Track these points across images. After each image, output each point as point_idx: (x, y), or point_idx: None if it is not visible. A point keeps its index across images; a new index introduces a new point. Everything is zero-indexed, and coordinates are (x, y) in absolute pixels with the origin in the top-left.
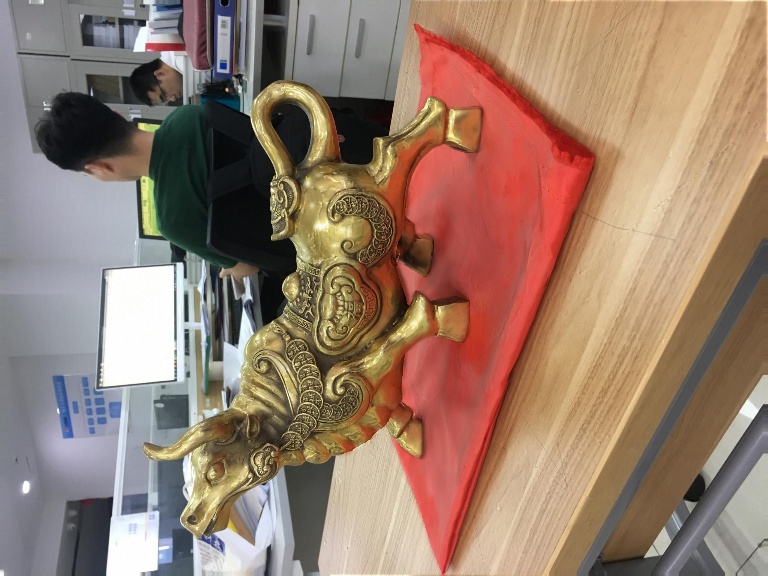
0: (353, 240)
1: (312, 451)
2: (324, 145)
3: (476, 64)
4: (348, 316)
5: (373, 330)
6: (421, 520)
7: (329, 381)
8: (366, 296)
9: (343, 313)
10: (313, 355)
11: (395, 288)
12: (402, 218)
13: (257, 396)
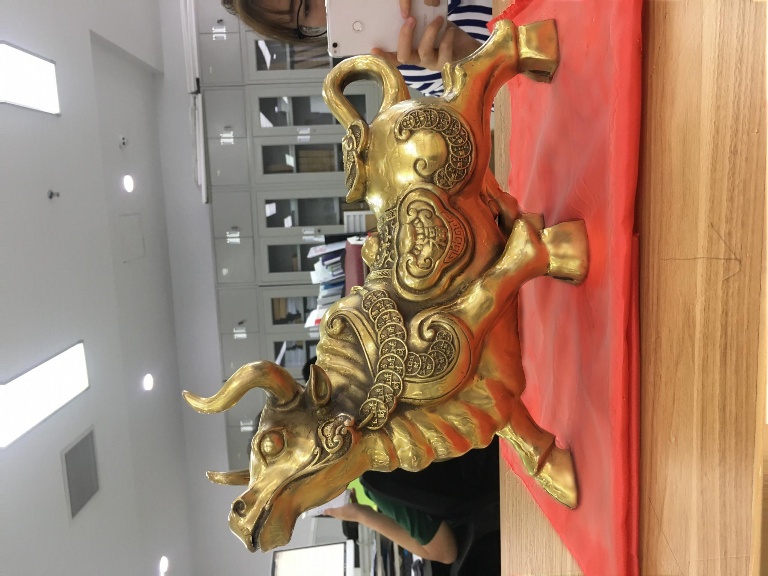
0: (426, 158)
1: (405, 440)
2: (395, 98)
3: None
4: (430, 245)
5: (467, 272)
6: None
7: (414, 325)
8: (450, 222)
9: (423, 241)
10: (393, 301)
11: (491, 230)
12: (483, 138)
13: (331, 366)
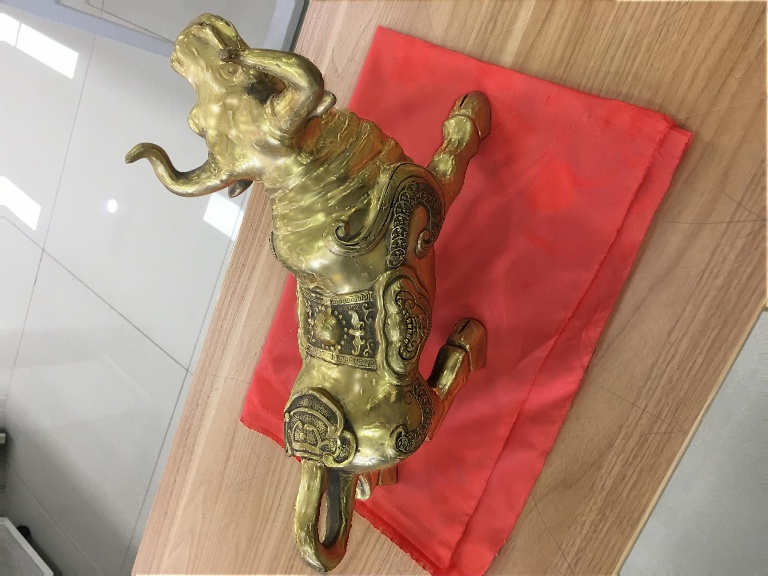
0: None
1: None
2: None
3: (365, 513)
4: None
5: None
6: (455, 22)
7: None
8: None
9: None
10: None
11: None
12: None
13: None
